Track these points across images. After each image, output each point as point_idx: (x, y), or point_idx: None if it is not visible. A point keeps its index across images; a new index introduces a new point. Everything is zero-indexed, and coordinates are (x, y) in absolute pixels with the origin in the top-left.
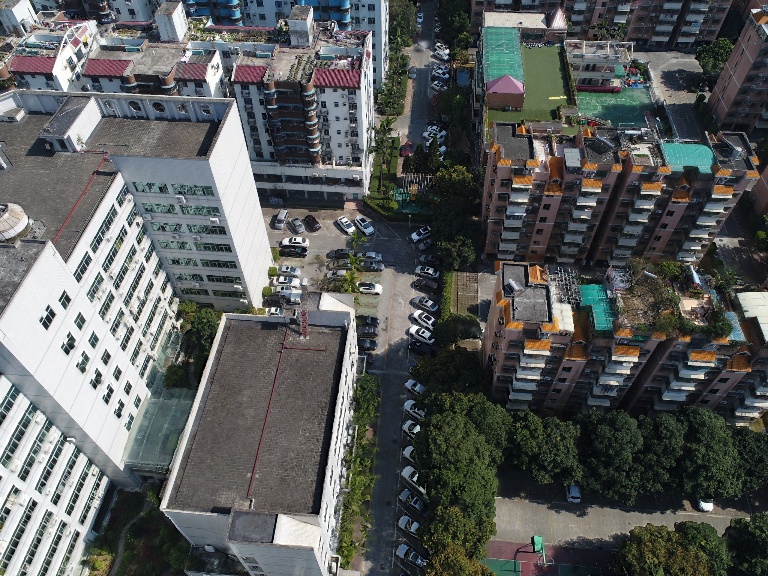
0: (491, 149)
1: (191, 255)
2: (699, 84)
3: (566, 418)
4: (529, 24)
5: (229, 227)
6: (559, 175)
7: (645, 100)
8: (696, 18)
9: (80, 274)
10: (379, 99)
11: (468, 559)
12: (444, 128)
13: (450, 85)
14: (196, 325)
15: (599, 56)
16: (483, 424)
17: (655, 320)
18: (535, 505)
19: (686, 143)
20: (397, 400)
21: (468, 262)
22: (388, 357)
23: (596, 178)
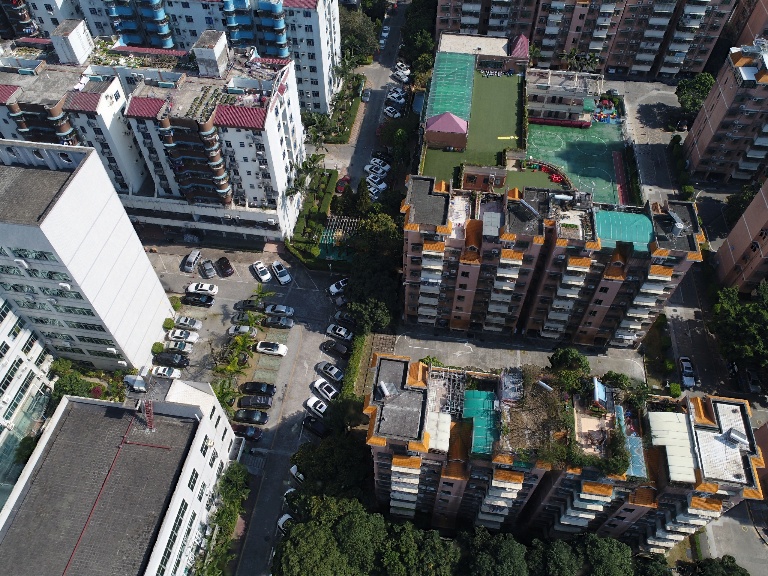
0: (401, 209)
1: (53, 316)
2: (677, 122)
3: (460, 525)
4: (488, 50)
5: (84, 292)
6: (477, 242)
7: (615, 138)
8: (680, 48)
9: None
10: (309, 131)
11: None
12: (389, 161)
13: (404, 111)
14: (58, 393)
15: (565, 88)
16: (345, 543)
17: (538, 449)
18: None
19: (625, 212)
20: (279, 487)
21: (382, 326)
22: (279, 433)
23: (517, 249)
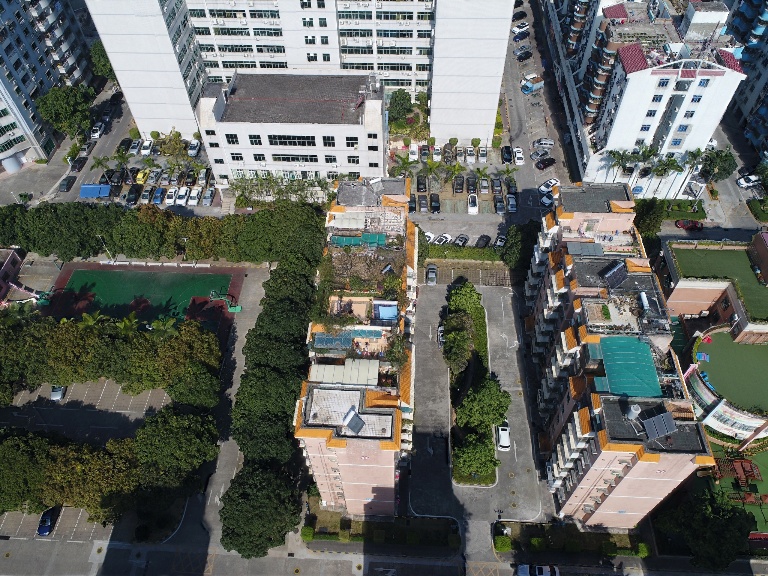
0: None
1: None
2: None
3: None
4: None
5: (435, 45)
6: None
7: None
8: None
9: None
10: (709, 152)
11: None
12: None
13: None
14: (395, 92)
15: None
16: None
17: None
18: None
19: (659, 375)
20: None
21: None
22: None
23: (567, 280)
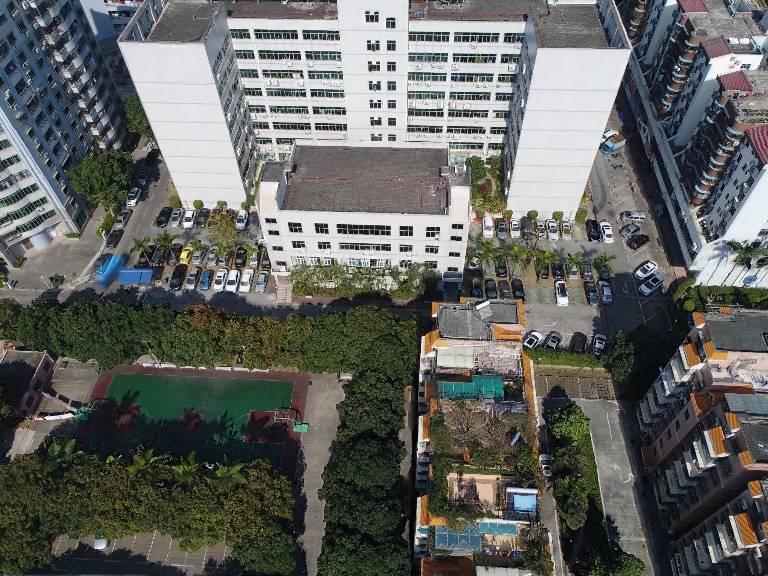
0: None
1: (514, 124)
2: None
3: None
4: None
5: (525, 118)
6: None
7: None
8: None
9: (433, 38)
10: None
11: (280, 351)
12: None
13: None
14: (468, 160)
15: None
16: None
17: None
18: (336, 430)
19: None
20: None
21: None
22: None
23: (729, 443)
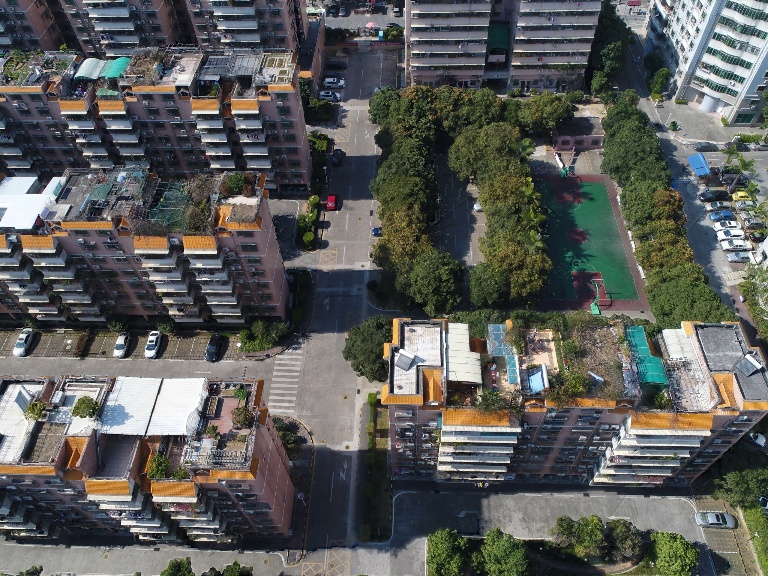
0: None
1: None
2: None
3: None
4: None
5: None
6: None
7: None
8: None
9: None
10: None
11: None
12: None
13: None
14: None
15: None
16: None
17: None
18: None
19: None
20: None
21: None
22: None
23: None
